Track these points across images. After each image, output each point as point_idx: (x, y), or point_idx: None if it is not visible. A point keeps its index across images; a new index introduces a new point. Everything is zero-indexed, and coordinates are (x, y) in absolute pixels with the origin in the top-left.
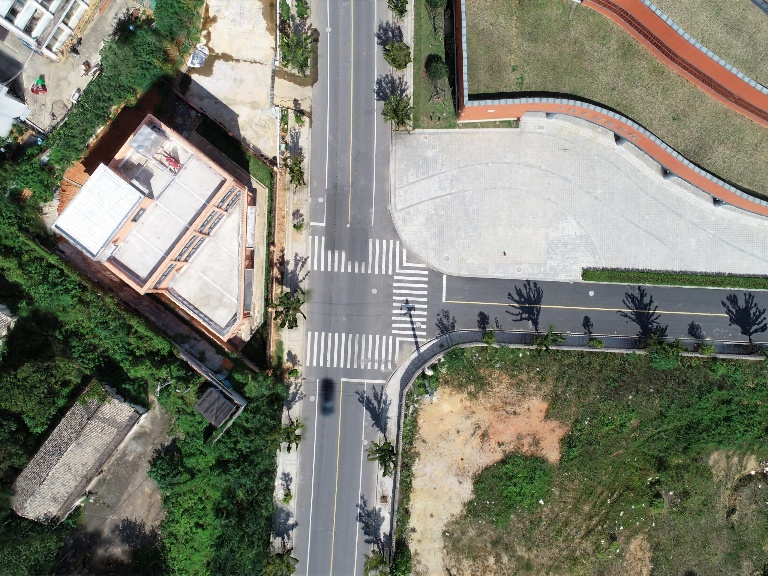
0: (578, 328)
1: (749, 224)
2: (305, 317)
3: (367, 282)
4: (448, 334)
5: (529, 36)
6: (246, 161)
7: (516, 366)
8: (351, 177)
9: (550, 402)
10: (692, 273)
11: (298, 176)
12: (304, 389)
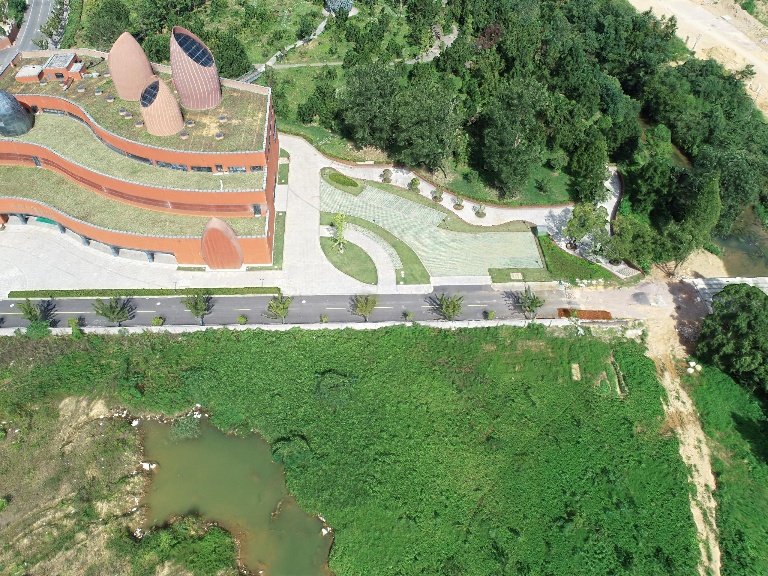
0: None
1: (137, 265)
2: None
3: None
4: None
5: (6, 180)
6: None
7: None
8: None
9: None
10: None
11: None
12: None
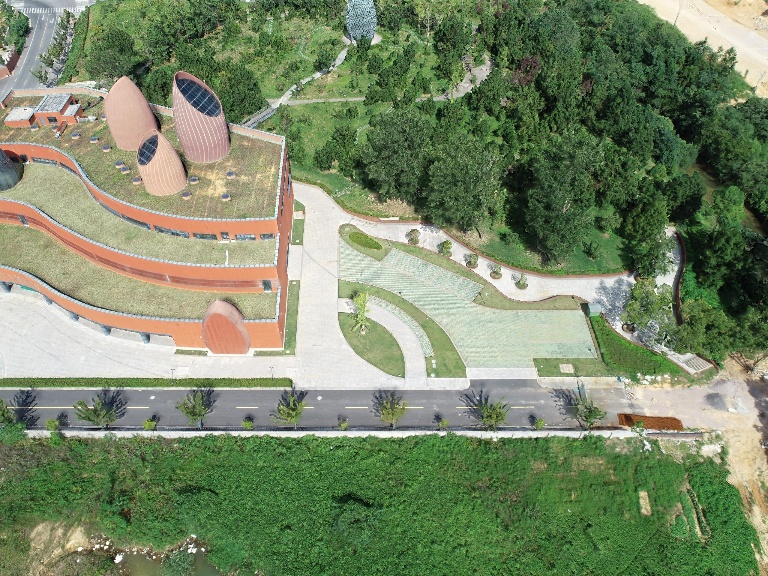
0: None
1: (130, 346)
2: None
3: None
4: None
5: None
6: None
7: None
8: None
9: None
10: None
11: None
12: None
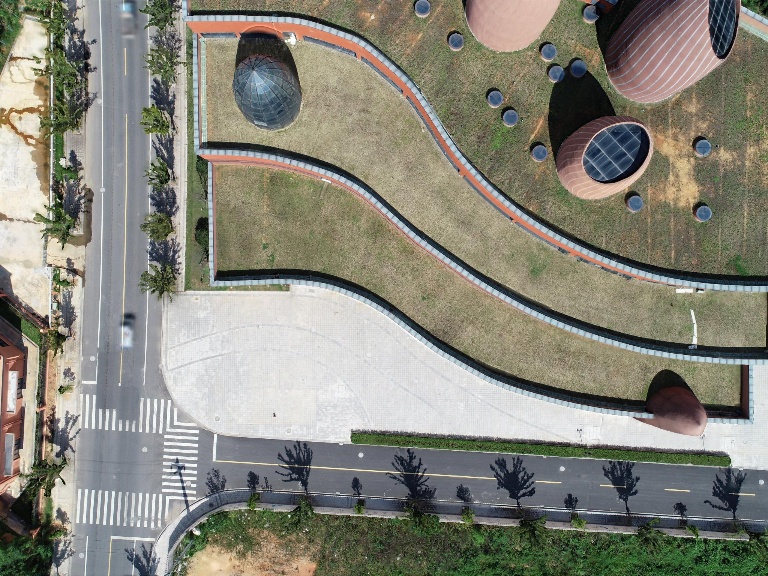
0: (347, 489)
1: None
2: (64, 482)
3: (138, 441)
4: (218, 493)
5: (280, 214)
6: (18, 319)
7: (284, 527)
8: (123, 336)
9: (318, 563)
10: (460, 437)
11: (55, 345)
12: (74, 546)
